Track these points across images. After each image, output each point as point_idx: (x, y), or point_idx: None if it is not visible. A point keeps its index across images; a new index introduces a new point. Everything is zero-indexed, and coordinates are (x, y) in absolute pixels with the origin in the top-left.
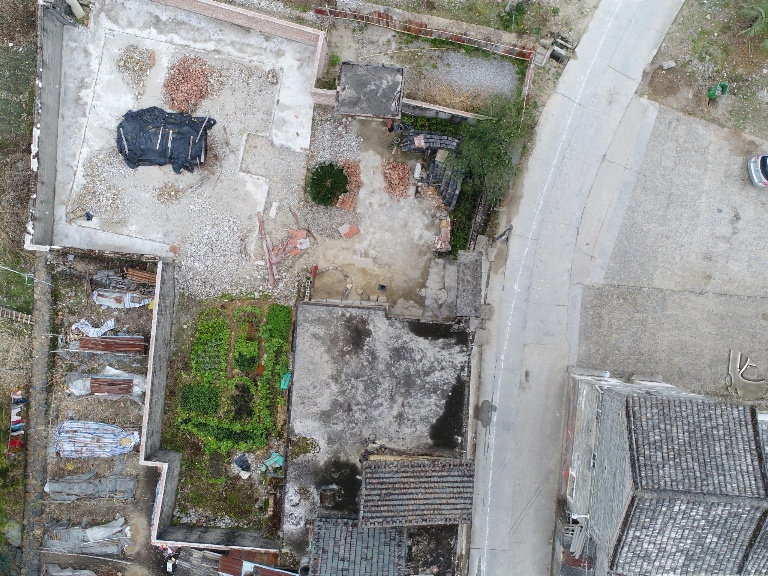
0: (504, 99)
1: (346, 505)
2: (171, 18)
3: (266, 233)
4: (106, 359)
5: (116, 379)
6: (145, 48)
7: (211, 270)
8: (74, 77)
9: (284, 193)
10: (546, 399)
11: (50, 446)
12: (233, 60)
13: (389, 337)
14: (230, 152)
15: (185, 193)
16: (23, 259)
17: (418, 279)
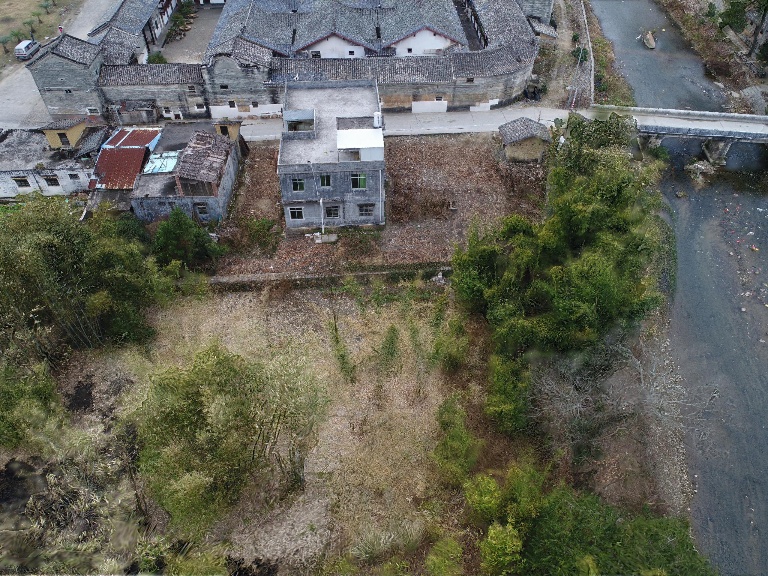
0: None
1: (73, 153)
2: None
3: None
4: None
5: None
6: None
7: None
8: None
9: None
10: None
11: None
12: None
13: None
14: None
15: None
16: None
17: None
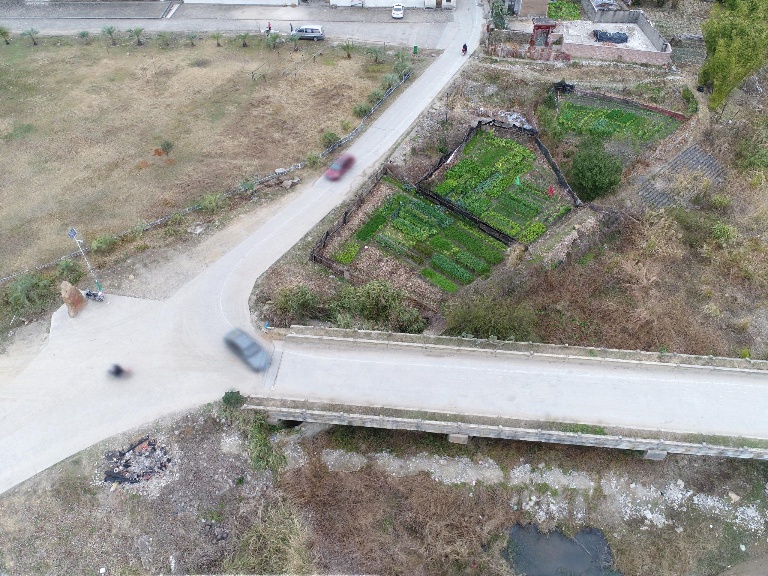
0: None
1: None
2: None
3: None
4: None
5: (601, 7)
6: None
7: None
8: None
9: None
10: None
11: (615, 2)
12: None
13: None
14: None
15: None
16: None
17: None
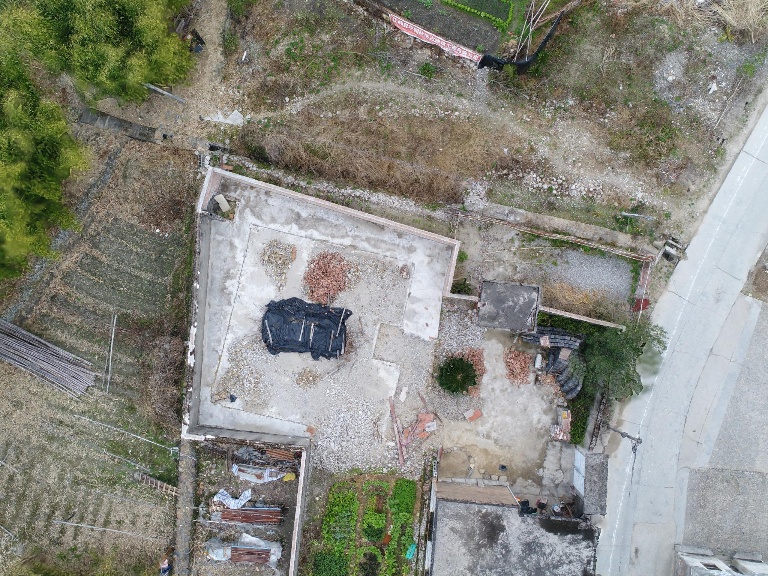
0: (619, 296)
1: None
2: (311, 215)
3: (396, 416)
4: (243, 526)
5: (255, 549)
6: (287, 243)
7: (345, 450)
8: (220, 268)
9: (413, 379)
10: (654, 574)
11: None
12: (368, 255)
13: (521, 532)
14: (365, 341)
15: (322, 378)
16: (166, 430)
17: (536, 460)
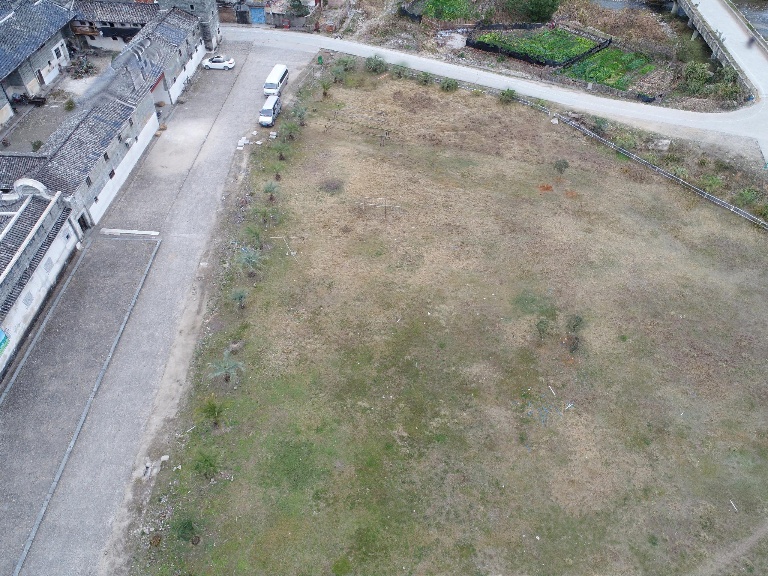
0: None
1: None
2: None
3: (282, 0)
4: None
5: None
6: None
7: None
8: None
9: None
10: None
11: None
12: None
13: None
14: None
15: None
16: None
17: None
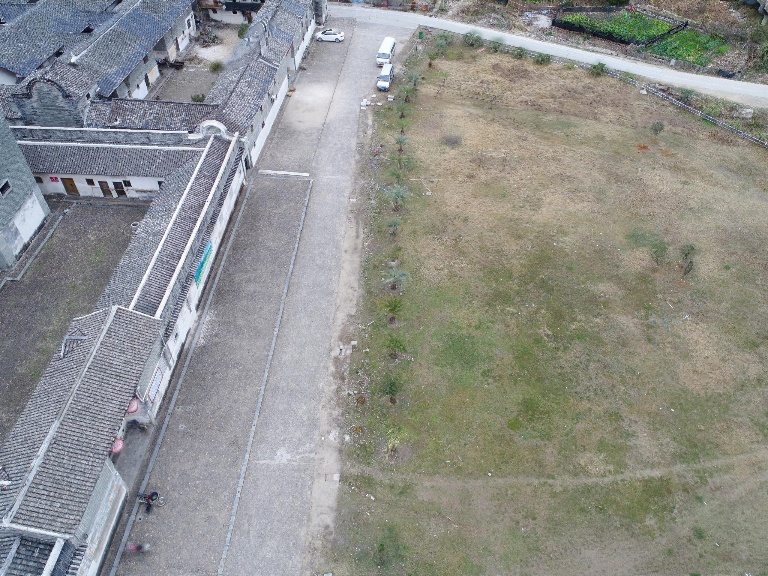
0: None
1: None
2: None
3: None
4: None
5: None
6: None
7: None
8: None
9: None
10: None
11: None
12: None
13: None
14: None
15: None
16: None
17: None
